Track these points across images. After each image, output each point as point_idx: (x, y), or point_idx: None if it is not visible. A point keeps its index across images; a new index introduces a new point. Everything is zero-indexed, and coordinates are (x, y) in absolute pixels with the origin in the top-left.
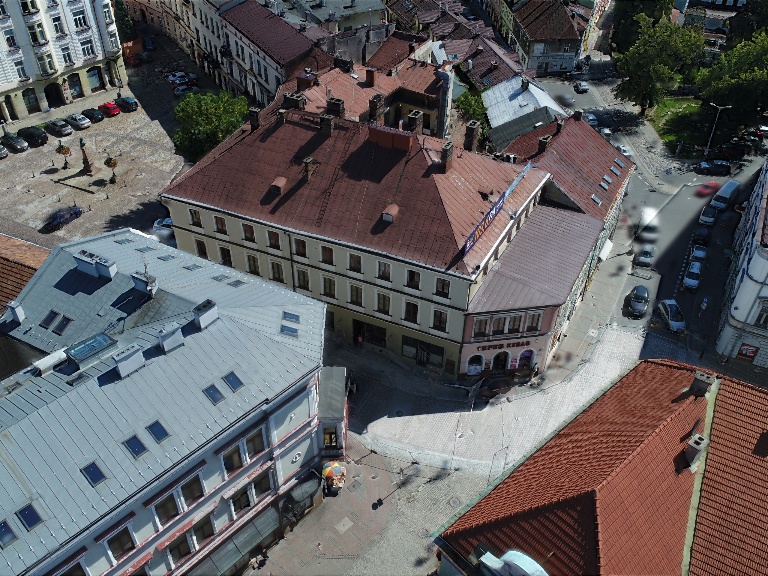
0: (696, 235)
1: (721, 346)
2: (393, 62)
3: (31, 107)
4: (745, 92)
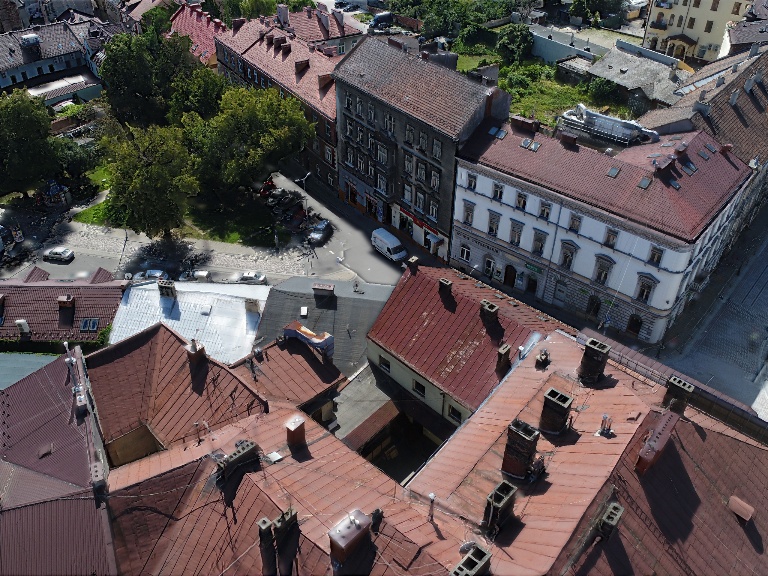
0: None
1: (657, 337)
2: (149, 398)
3: None
4: (269, 155)
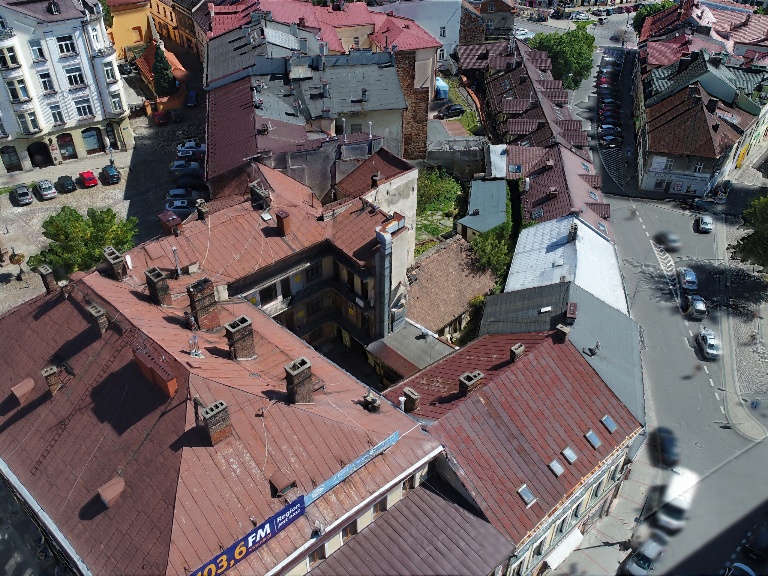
0: (748, 542)
1: None
2: (364, 190)
3: (13, 164)
4: None
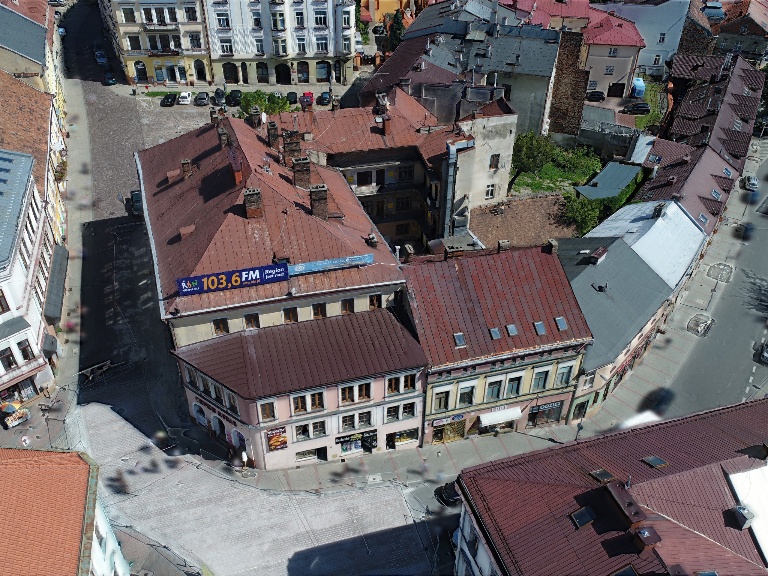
0: None
1: None
2: None
3: (263, 78)
4: None
